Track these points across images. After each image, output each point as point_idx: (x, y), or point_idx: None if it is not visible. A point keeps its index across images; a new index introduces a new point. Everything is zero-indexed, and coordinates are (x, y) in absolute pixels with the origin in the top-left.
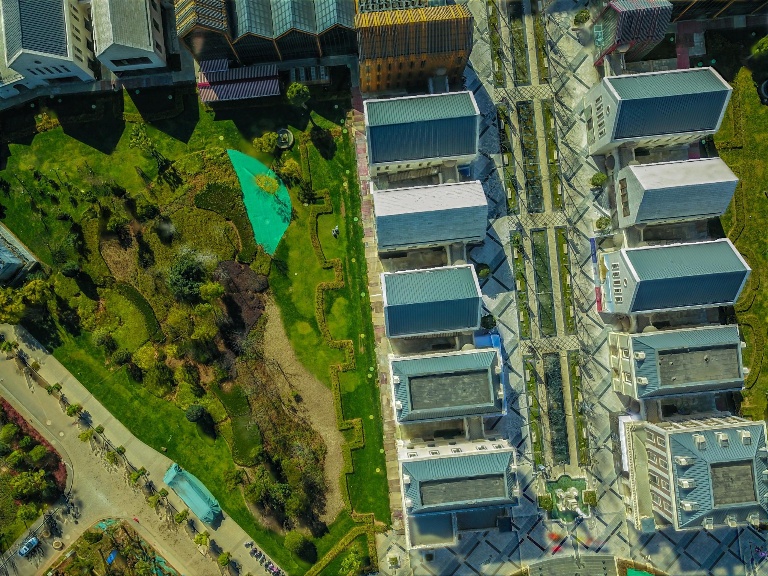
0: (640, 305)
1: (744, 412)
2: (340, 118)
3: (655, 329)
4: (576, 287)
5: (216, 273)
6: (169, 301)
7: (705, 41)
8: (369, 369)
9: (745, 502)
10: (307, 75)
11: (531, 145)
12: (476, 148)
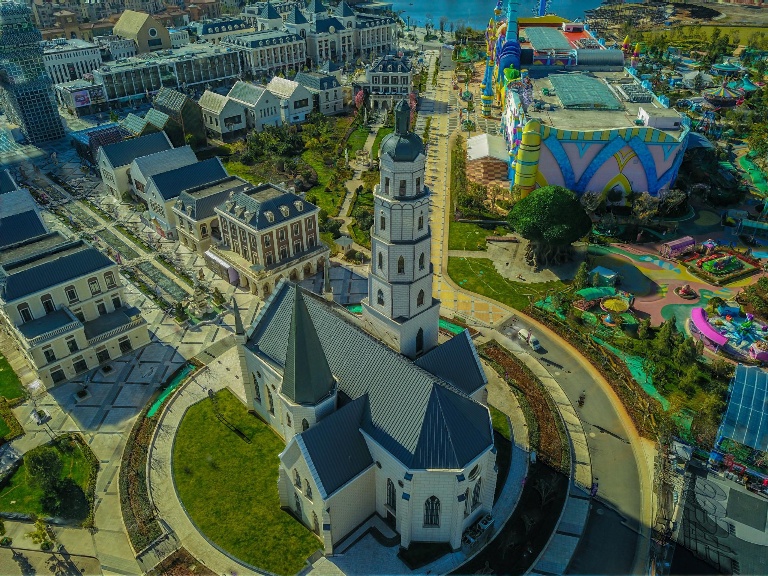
0: (168, 195)
1: None
2: None
3: None
4: None
5: None
6: None
7: None
8: None
9: None
10: None
11: None
12: None
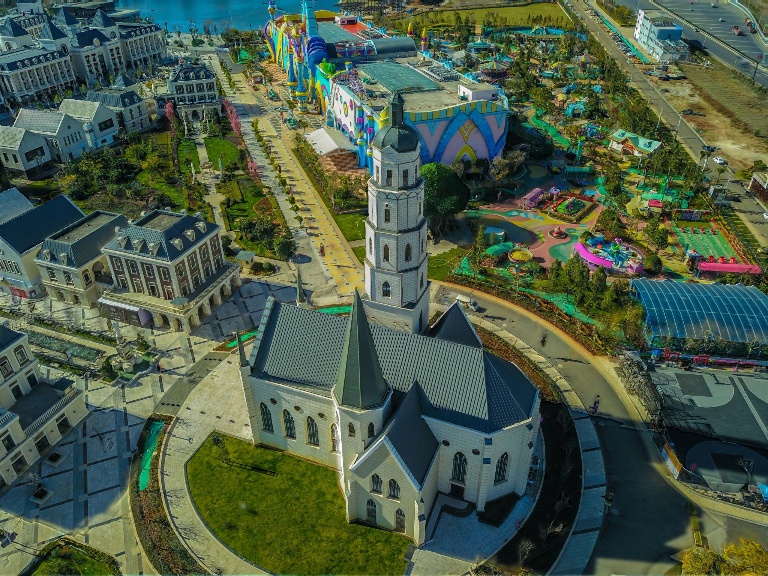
0: (21, 247)
1: None
2: None
3: None
4: None
5: None
6: None
7: None
8: None
9: None
10: None
11: None
12: None
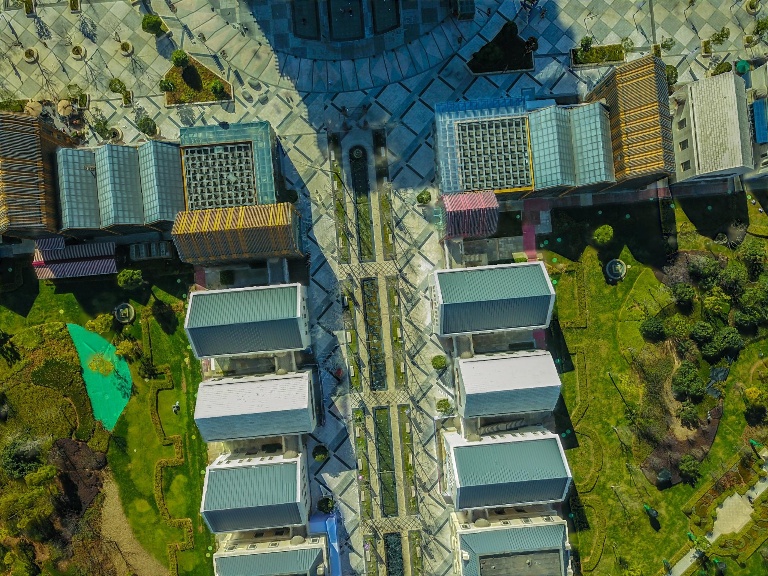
0: (467, 503)
1: None
2: (182, 293)
3: (485, 524)
4: (418, 467)
5: (52, 451)
6: (3, 479)
7: (551, 219)
8: (207, 548)
9: None
10: (147, 251)
11: (375, 322)
12: (303, 343)
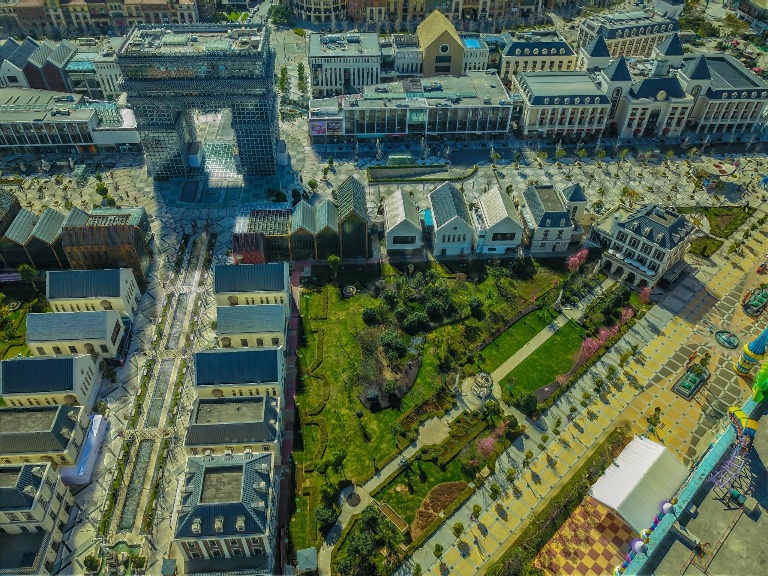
0: (203, 379)
1: (303, 490)
2: None
3: None
4: None
5: None
6: None
7: (311, 270)
8: None
9: None
10: None
11: (181, 314)
12: (120, 292)
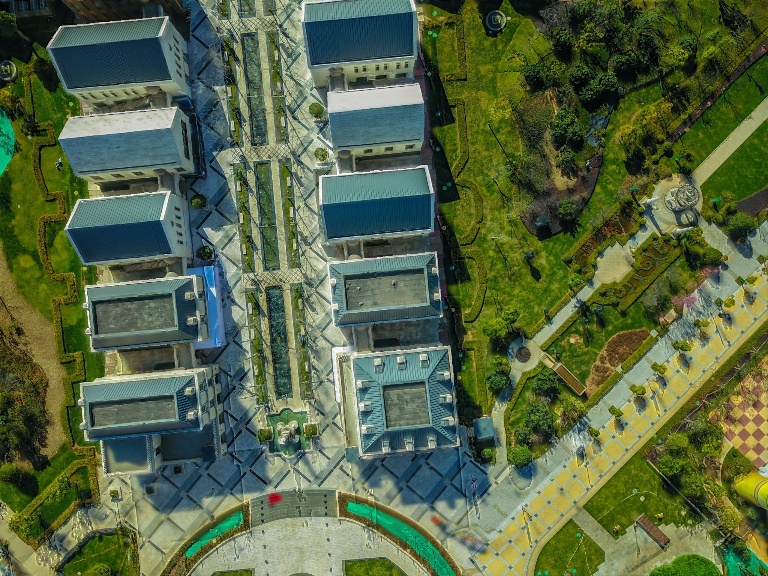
0: (335, 231)
1: (466, 345)
2: None
3: (356, 257)
4: (298, 220)
5: None
6: None
7: None
8: None
9: (419, 425)
10: (26, 5)
11: (256, 77)
12: (170, 73)
